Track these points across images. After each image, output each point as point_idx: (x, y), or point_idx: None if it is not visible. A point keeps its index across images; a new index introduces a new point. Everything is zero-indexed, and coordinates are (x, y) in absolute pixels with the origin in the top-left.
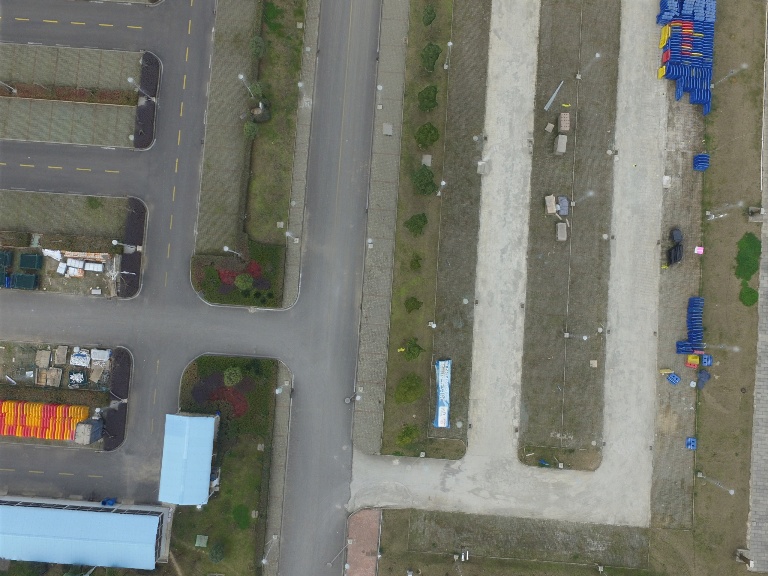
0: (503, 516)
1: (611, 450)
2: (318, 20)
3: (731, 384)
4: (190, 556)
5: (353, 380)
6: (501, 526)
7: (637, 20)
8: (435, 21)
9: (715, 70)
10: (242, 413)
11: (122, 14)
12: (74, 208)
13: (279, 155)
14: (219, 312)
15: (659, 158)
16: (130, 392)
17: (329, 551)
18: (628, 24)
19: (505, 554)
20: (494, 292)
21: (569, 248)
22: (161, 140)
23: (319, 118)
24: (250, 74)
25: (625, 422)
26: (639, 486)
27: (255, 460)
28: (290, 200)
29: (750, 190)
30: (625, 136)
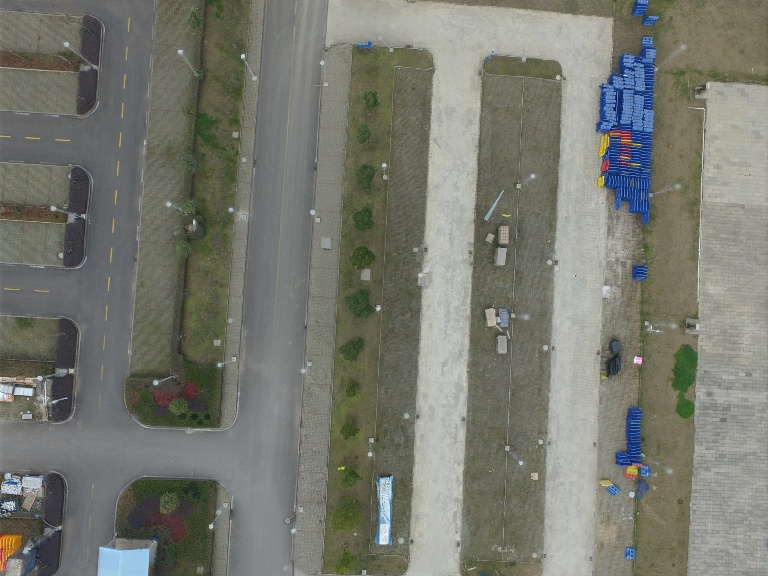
0: None
1: (552, 562)
2: (254, 129)
3: (668, 495)
4: None
5: (293, 500)
6: None
7: (577, 128)
8: (374, 130)
9: (654, 179)
10: (180, 538)
11: (49, 126)
12: (2, 330)
13: (215, 271)
14: (155, 434)
15: (599, 268)
16: (64, 518)
17: None
18: (568, 132)
19: None
20: (435, 406)
21: (510, 360)
22: (92, 258)
23: (256, 232)
24: (183, 190)
25: (565, 533)
26: None
27: None
28: (227, 317)
29: (687, 301)
30: (565, 246)
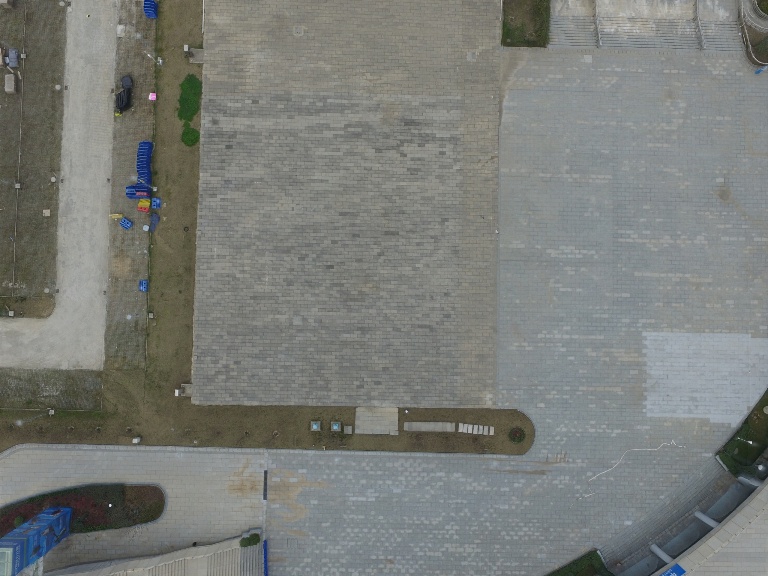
0: None
1: (64, 296)
2: None
3: (174, 223)
4: None
5: None
6: None
7: None
8: None
9: None
10: None
11: None
12: None
13: None
14: None
15: (113, 8)
16: None
17: None
18: None
19: None
20: None
21: (21, 100)
22: None
23: None
24: None
25: (78, 268)
26: (93, 330)
27: None
28: None
29: (192, 32)
30: None
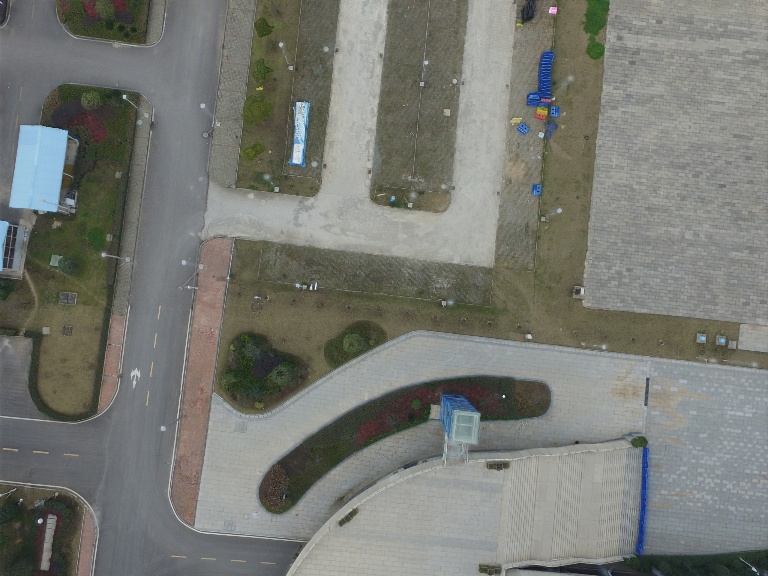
0: (353, 252)
1: (460, 194)
2: None
3: (575, 132)
4: (44, 274)
5: (212, 116)
6: (350, 261)
7: None
8: None
9: None
10: (100, 139)
11: None
12: None
13: None
14: (84, 45)
15: None
16: None
17: (181, 275)
18: None
19: (353, 287)
20: (354, 41)
21: (428, 3)
22: None
23: None
24: None
25: (474, 168)
26: (485, 228)
27: (112, 186)
28: None
29: None
30: None
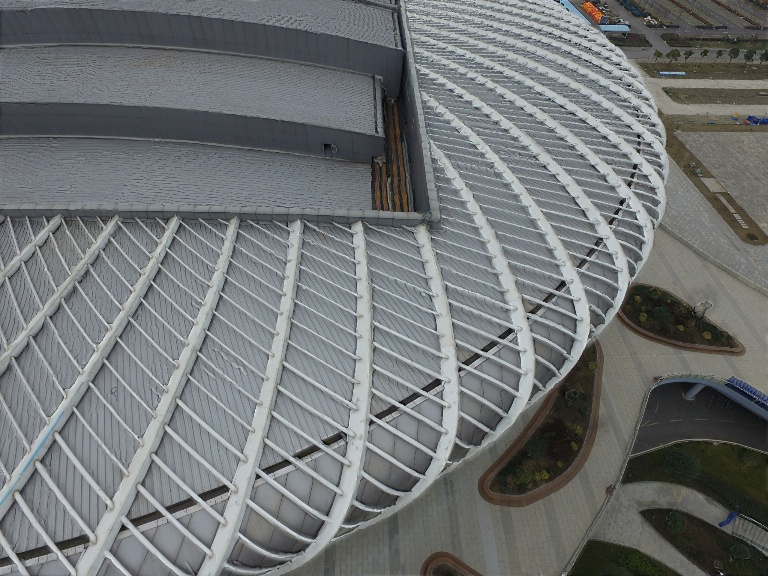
0: None
1: None
2: None
3: None
4: None
5: None
6: None
7: None
8: None
9: None
10: None
11: None
12: None
13: None
14: (658, 38)
15: None
16: None
17: None
18: None
19: None
20: None
21: (759, 96)
22: None
23: None
24: None
25: None
26: None
27: None
28: None
29: None
30: None
